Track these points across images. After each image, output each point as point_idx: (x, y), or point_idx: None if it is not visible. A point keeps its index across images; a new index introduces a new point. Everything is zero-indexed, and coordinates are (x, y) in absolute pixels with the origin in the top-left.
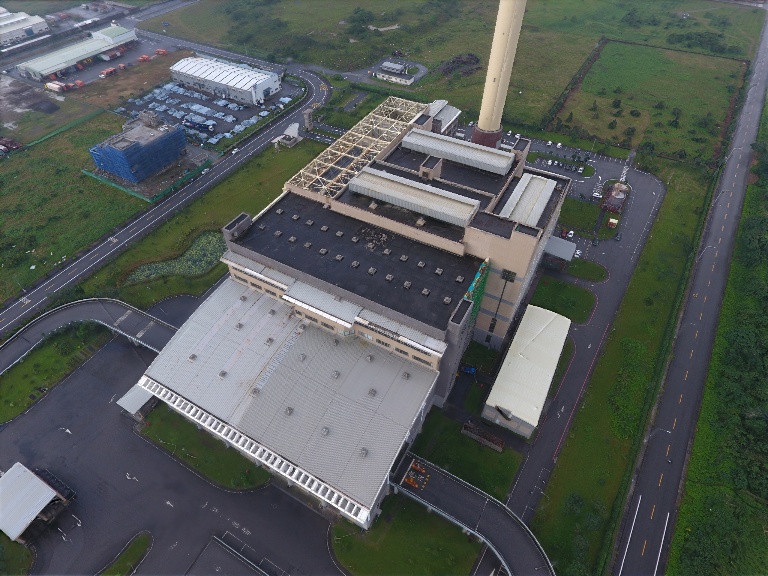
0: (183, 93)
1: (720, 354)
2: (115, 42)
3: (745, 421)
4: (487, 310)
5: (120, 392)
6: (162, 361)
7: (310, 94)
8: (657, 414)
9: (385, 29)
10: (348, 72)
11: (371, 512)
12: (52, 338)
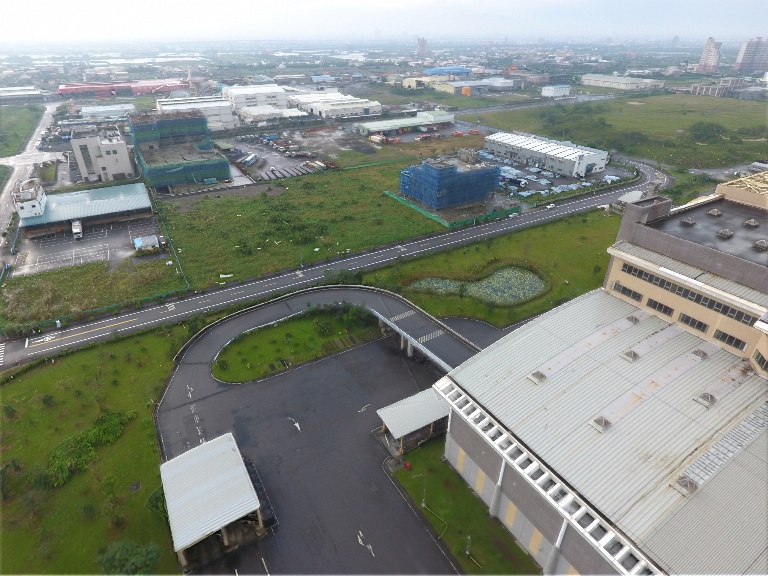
0: (493, 158)
1: None
2: (435, 120)
3: None
4: None
5: (376, 404)
6: (481, 365)
7: (644, 178)
8: None
9: (744, 140)
10: (694, 169)
11: None
12: (315, 313)
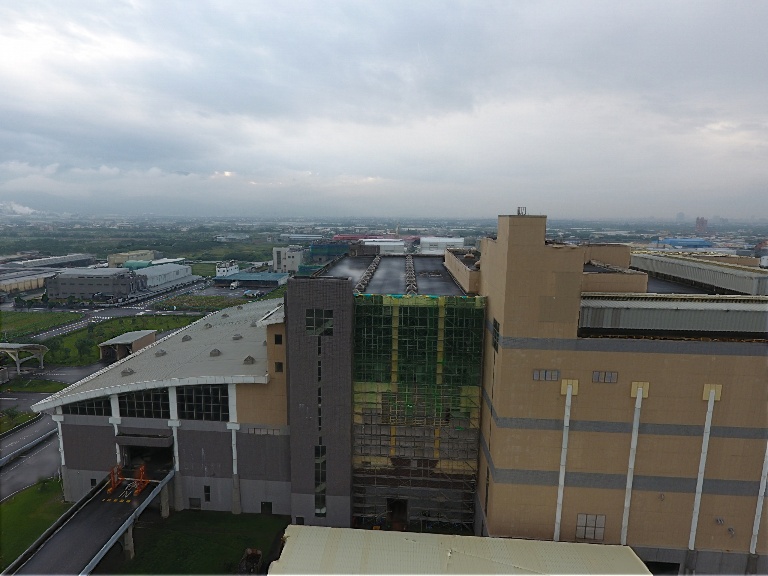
0: None
1: None
2: None
3: None
4: (485, 442)
5: None
6: (235, 307)
7: None
8: None
9: None
10: None
11: (72, 457)
12: None
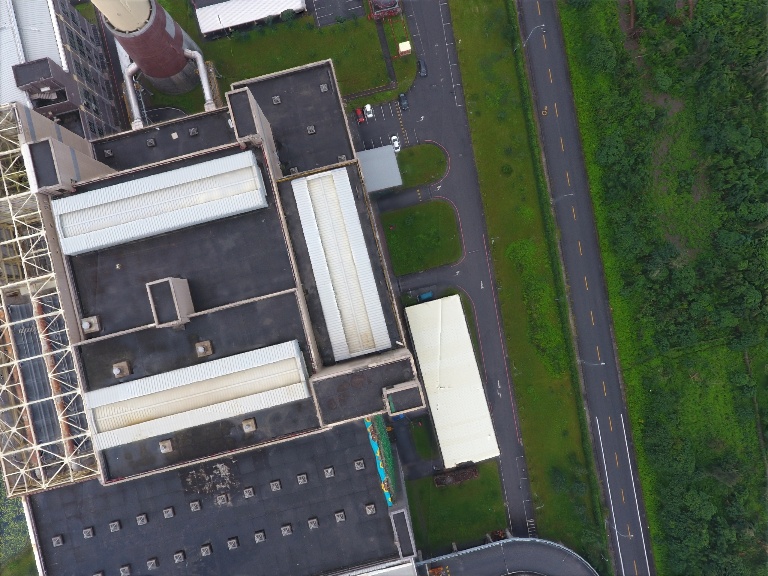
0: None
1: (599, 193)
2: None
3: (649, 277)
4: None
5: None
6: None
7: None
8: (575, 320)
9: None
10: None
11: None
12: None
